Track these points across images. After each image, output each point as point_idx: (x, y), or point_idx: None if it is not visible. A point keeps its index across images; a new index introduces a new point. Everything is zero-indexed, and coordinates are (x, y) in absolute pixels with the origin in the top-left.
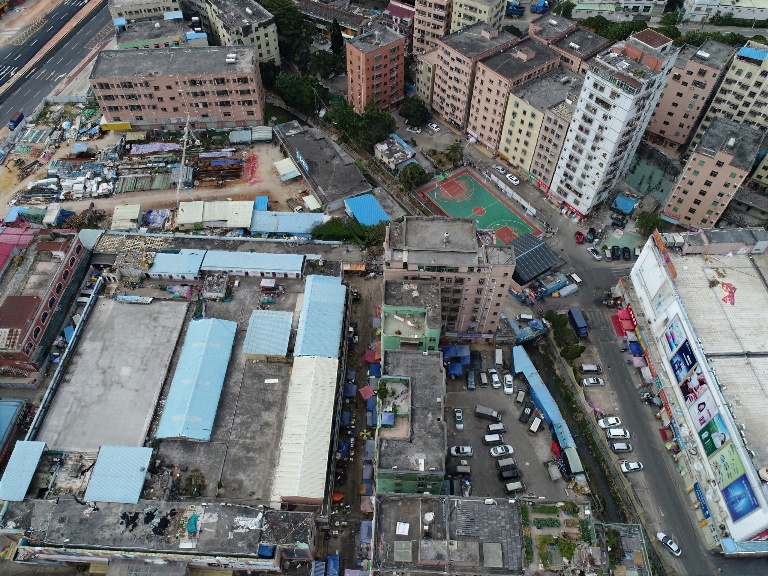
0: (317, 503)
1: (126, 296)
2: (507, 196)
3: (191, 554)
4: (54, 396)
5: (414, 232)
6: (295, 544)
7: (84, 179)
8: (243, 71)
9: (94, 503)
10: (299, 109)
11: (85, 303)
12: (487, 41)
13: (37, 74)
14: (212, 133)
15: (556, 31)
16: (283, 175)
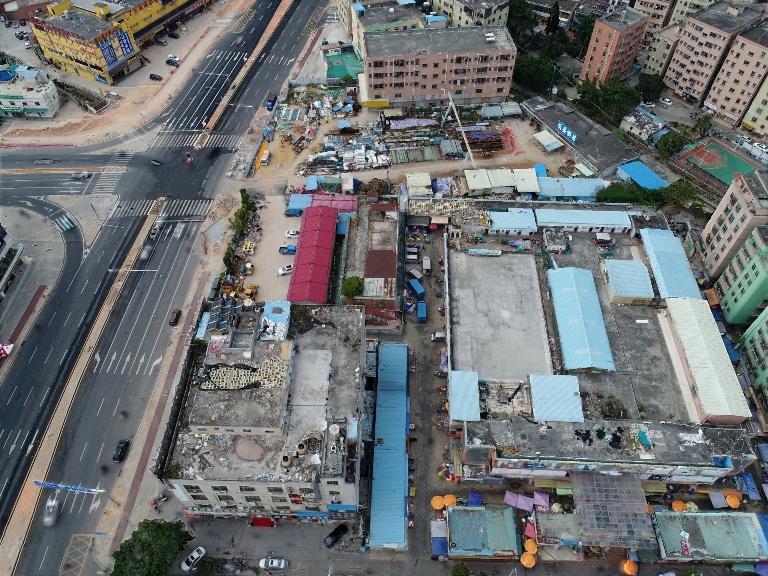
0: (735, 424)
1: (477, 249)
2: (761, 163)
3: (654, 464)
4: None
5: None
6: (743, 455)
7: (364, 151)
8: (505, 49)
9: (545, 422)
10: (533, 87)
11: (414, 260)
12: (735, 17)
13: (268, 59)
14: (460, 109)
15: None
16: (547, 146)
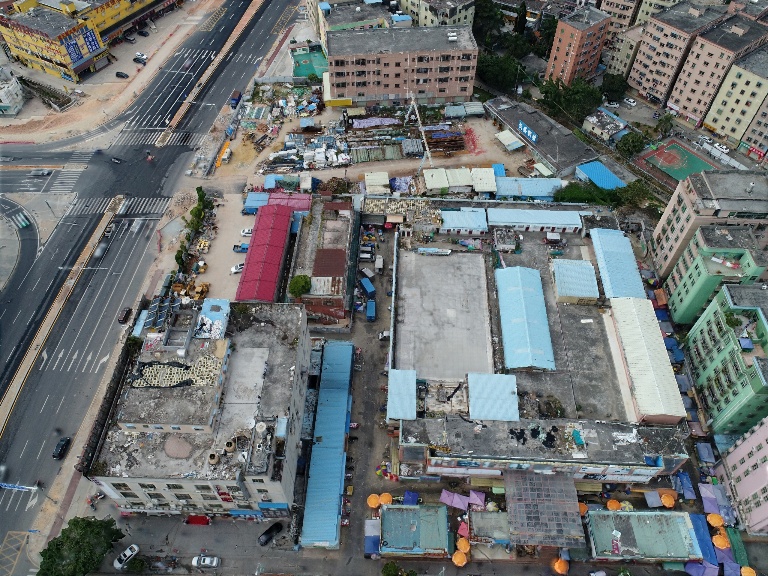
0: (672, 423)
1: (426, 248)
2: (721, 163)
3: (586, 463)
4: (396, 334)
5: (715, 184)
6: (675, 455)
7: None
8: (466, 48)
9: (480, 421)
10: (498, 86)
11: (367, 259)
12: (696, 18)
13: (236, 57)
14: (424, 109)
15: (758, 9)
16: (508, 145)
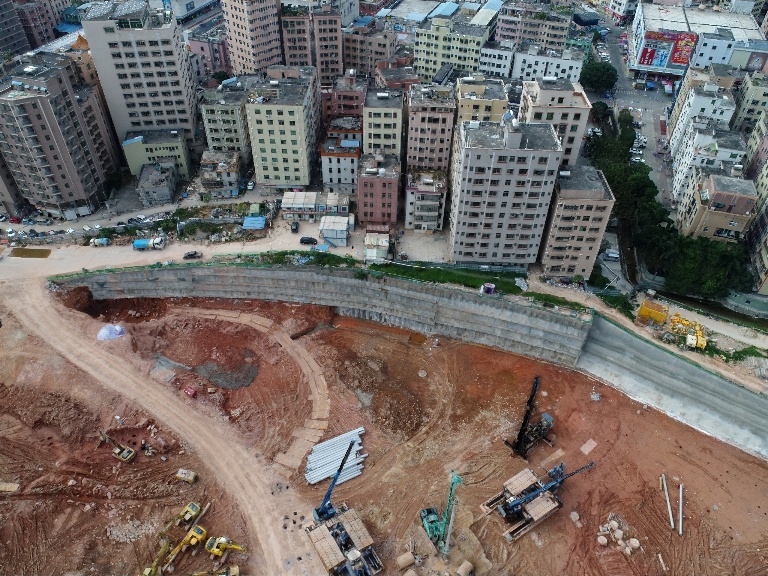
0: None
1: None
2: None
3: None
4: None
5: None
6: None
7: None
8: None
9: None
10: None
11: None
12: None
13: None
14: None
15: None
16: None
